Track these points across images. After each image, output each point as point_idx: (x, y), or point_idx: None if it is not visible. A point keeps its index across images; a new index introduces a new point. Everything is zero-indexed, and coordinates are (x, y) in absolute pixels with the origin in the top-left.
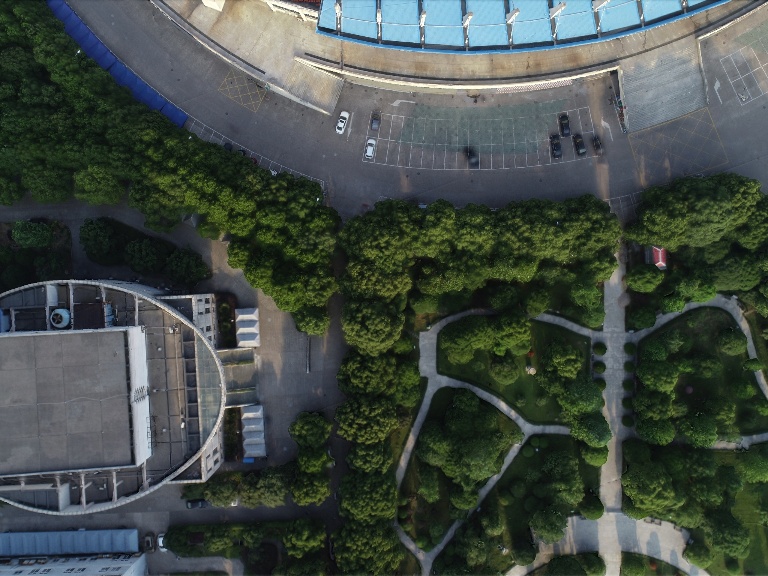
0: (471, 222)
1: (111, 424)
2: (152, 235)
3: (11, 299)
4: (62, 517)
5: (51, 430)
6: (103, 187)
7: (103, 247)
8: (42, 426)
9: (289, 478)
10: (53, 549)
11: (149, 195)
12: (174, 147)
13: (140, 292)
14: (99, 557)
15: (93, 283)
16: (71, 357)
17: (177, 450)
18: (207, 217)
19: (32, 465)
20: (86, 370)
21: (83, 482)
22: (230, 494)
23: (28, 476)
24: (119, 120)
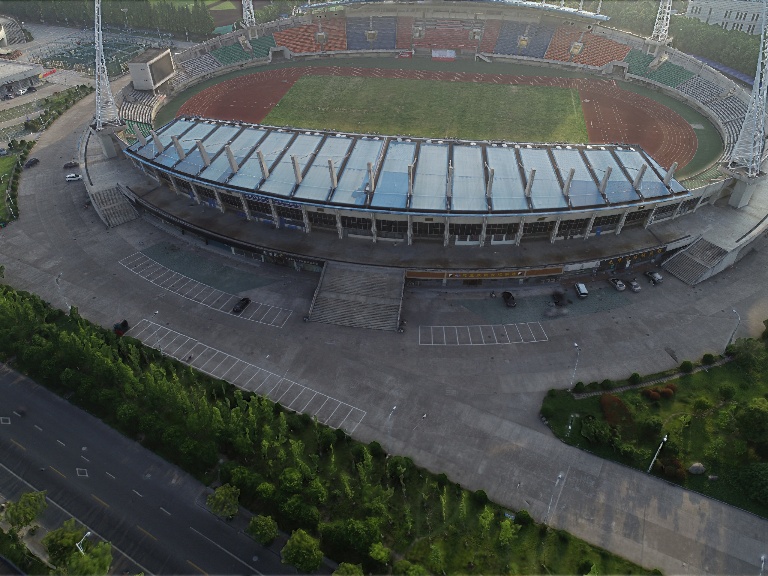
0: (559, 5)
1: None
2: None
3: None
4: None
5: None
6: None
7: None
8: None
9: (659, 1)
10: None
11: None
12: None
13: (715, 3)
14: None
15: (736, 1)
16: None
17: None
18: None
19: None
20: None
21: None
22: None
23: None
24: None
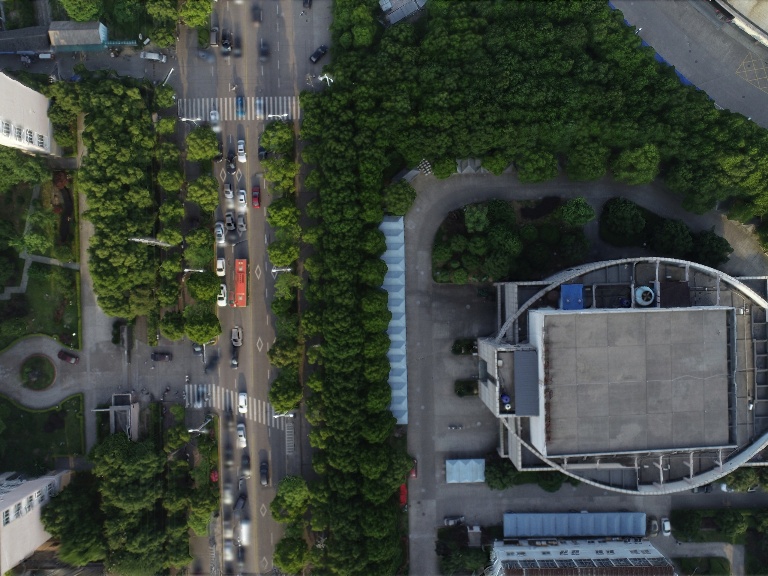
0: None
1: (712, 403)
2: (665, 217)
3: (593, 275)
4: (564, 499)
5: (658, 408)
6: (653, 166)
7: (640, 227)
8: (650, 403)
9: None
10: (561, 531)
11: (707, 175)
12: (739, 127)
13: None
14: (608, 540)
15: (681, 261)
16: (678, 335)
17: (741, 432)
18: (757, 199)
19: (639, 443)
20: (692, 348)
21: (661, 462)
22: (754, 479)
23: (638, 454)
24: (685, 99)
